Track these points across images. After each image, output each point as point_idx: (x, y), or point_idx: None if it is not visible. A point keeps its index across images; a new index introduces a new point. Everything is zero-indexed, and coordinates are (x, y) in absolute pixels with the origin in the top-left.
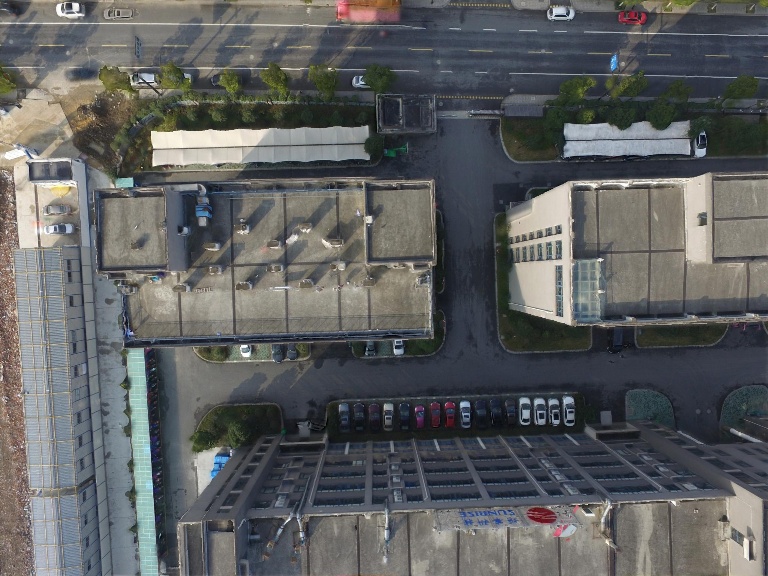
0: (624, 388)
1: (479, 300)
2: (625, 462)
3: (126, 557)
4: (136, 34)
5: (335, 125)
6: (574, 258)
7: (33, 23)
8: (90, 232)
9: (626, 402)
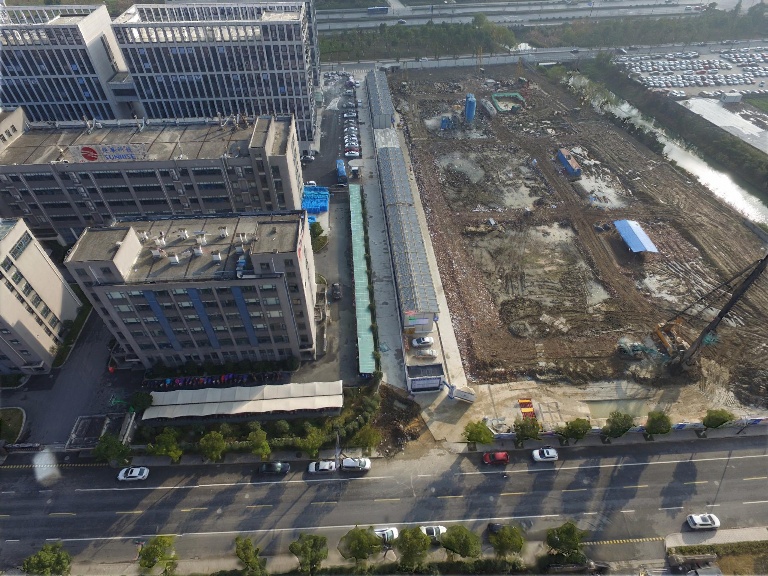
0: None
1: None
2: (40, 205)
3: (372, 195)
4: (365, 514)
5: (177, 428)
6: None
7: (473, 520)
8: (401, 344)
9: None
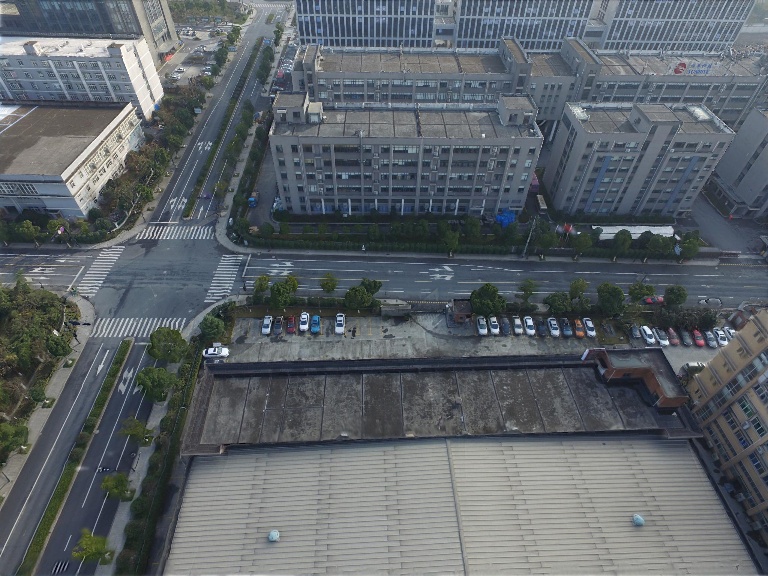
0: None
1: None
2: None
3: None
4: None
5: None
6: (710, 121)
7: None
8: None
9: None
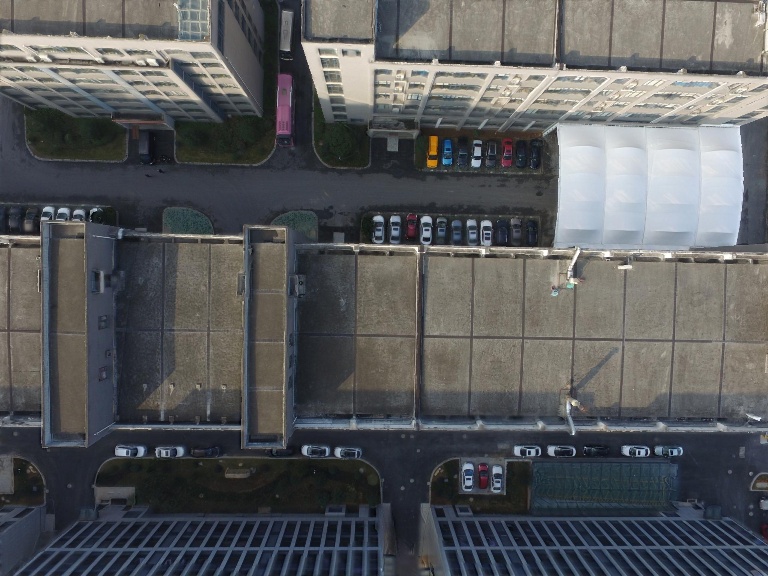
0: (161, 205)
1: (5, 101)
2: None
3: None
4: None
5: None
6: None
7: None
8: None
9: (163, 220)
